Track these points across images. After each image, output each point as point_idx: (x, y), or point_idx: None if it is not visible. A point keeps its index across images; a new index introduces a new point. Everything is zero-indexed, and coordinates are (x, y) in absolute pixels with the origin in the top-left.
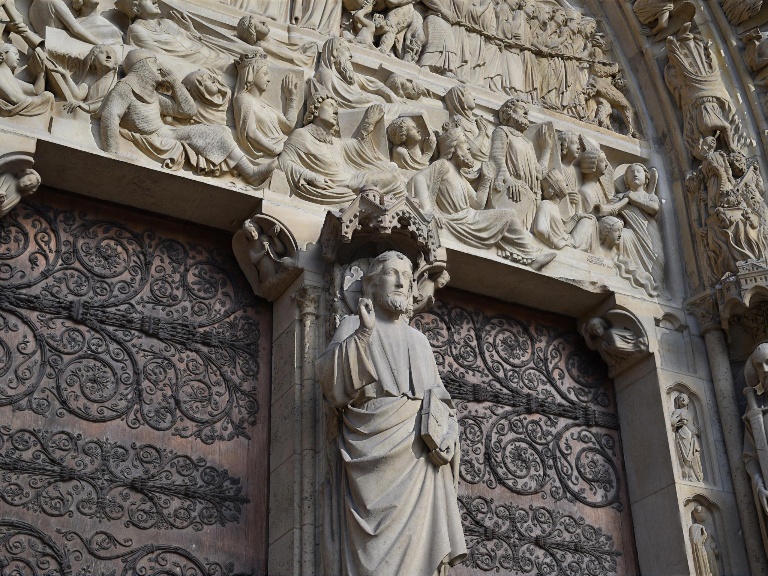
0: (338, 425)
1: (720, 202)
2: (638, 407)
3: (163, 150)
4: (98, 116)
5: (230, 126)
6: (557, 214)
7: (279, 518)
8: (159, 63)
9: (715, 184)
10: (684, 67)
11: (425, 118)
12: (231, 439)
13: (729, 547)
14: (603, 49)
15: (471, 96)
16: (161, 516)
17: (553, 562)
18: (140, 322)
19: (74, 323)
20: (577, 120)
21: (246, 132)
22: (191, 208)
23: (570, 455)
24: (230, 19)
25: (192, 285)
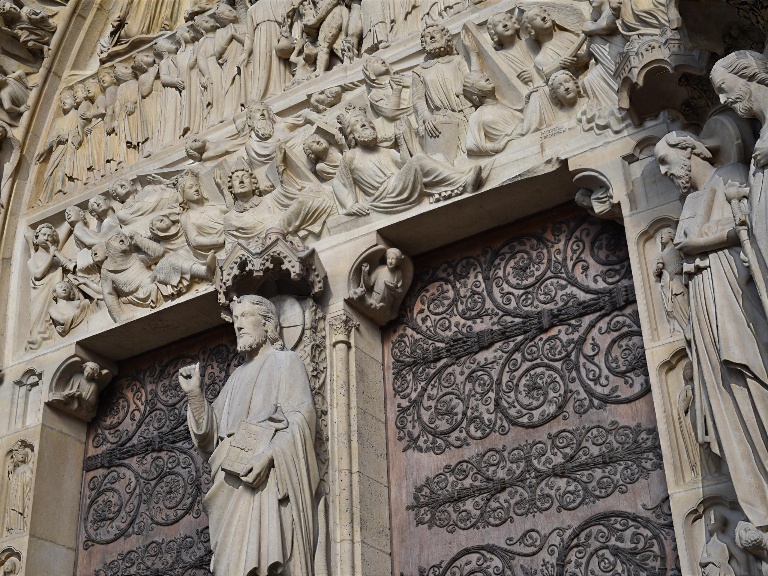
0: None
1: None
2: None
3: (146, 298)
4: None
5: None
6: (489, 116)
7: None
8: None
9: None
10: None
11: (323, 125)
12: None
13: None
14: None
15: (378, 63)
16: None
17: (578, 487)
18: None
19: (158, 453)
20: None
21: (191, 244)
22: (206, 318)
23: (598, 355)
24: None
25: None
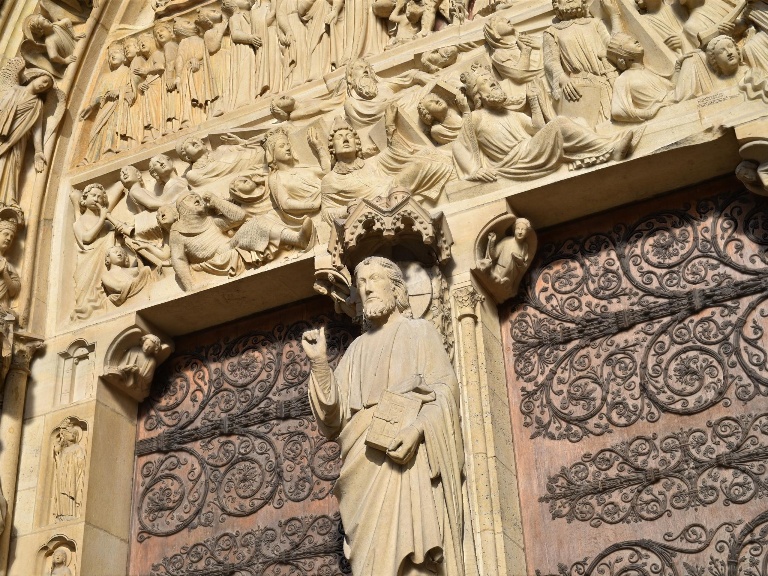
0: None
1: None
2: None
3: (224, 265)
4: None
5: (277, 208)
6: (638, 81)
7: None
8: (204, 194)
9: None
10: None
11: (442, 84)
12: None
13: None
14: None
15: (503, 22)
16: None
17: (748, 479)
18: None
19: (227, 437)
20: None
21: (281, 207)
22: (288, 291)
23: (761, 338)
24: None
25: None
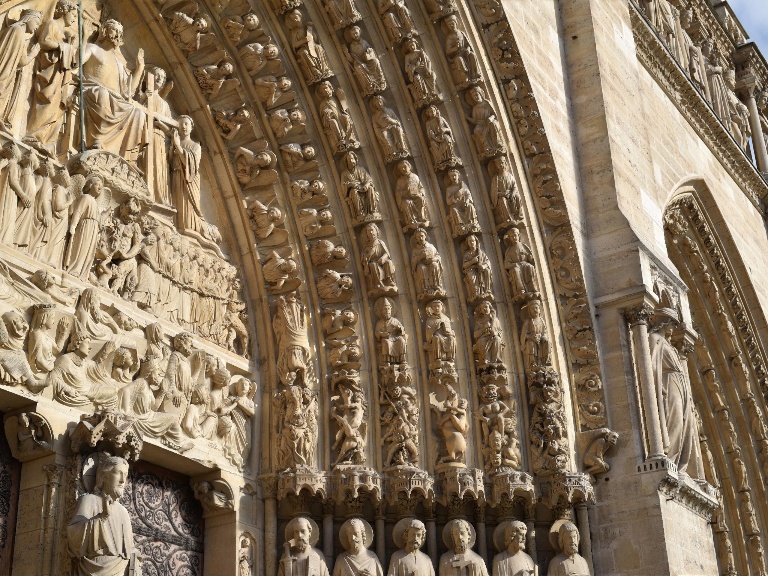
0: (72, 564)
1: (293, 421)
2: (219, 542)
3: None
4: None
5: (25, 350)
6: None
7: None
8: None
9: (292, 408)
10: (287, 322)
11: None
12: None
13: None
14: (238, 291)
15: (163, 332)
16: None
17: None
18: None
19: None
20: (217, 345)
21: (36, 357)
22: None
23: (174, 569)
24: (29, 267)
25: None
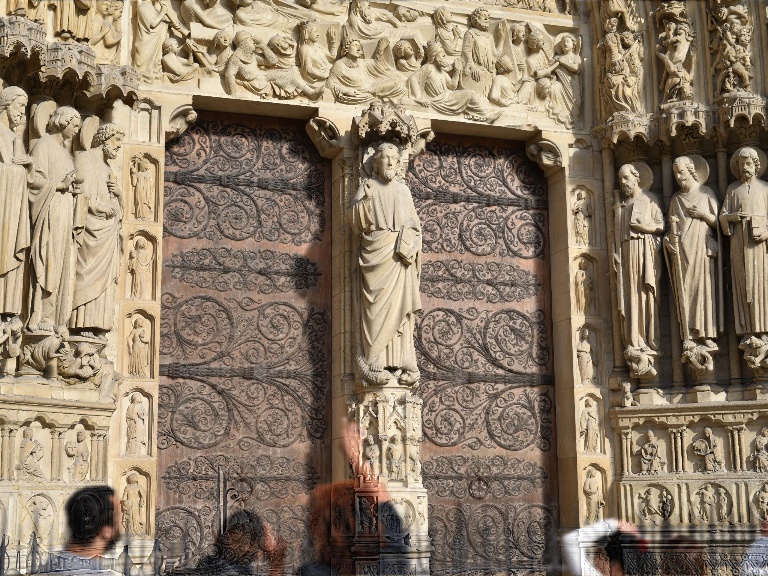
0: (360, 241)
1: (611, 69)
2: (557, 198)
3: (261, 89)
4: (224, 74)
5: (298, 65)
6: (506, 84)
7: (336, 285)
8: (254, 36)
9: (609, 56)
10: None
11: (416, 39)
12: (311, 242)
13: (599, 282)
14: None
15: (449, 14)
16: (276, 286)
17: (497, 293)
18: (258, 182)
19: (223, 187)
20: (527, 10)
21: (307, 70)
22: (281, 113)
23: (514, 229)
24: None
25: (285, 155)
